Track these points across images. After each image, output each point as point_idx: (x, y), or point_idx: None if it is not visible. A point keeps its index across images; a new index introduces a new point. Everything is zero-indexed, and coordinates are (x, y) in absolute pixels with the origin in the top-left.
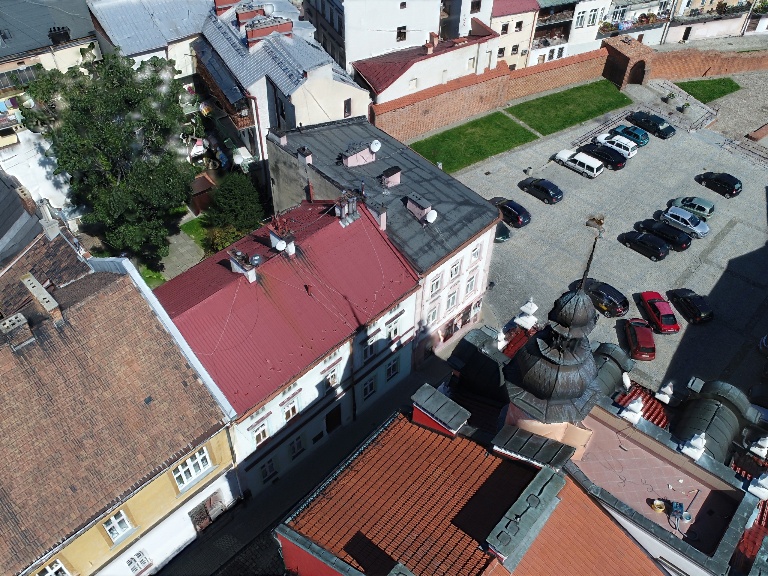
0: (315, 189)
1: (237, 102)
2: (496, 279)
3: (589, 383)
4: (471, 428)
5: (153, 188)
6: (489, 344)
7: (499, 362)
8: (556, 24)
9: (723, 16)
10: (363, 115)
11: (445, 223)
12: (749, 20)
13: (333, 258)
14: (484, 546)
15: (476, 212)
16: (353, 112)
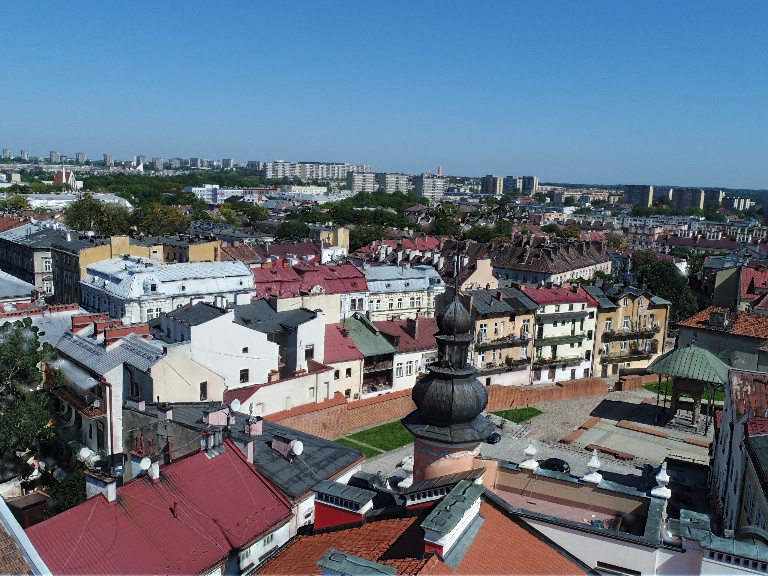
0: (175, 446)
1: (89, 397)
2: None
3: (482, 400)
4: (379, 509)
5: (1, 427)
6: (379, 485)
7: (392, 493)
8: (380, 373)
9: (512, 367)
10: (218, 401)
11: (311, 460)
12: (533, 372)
13: (200, 485)
14: (419, 556)
15: (340, 452)
16: (209, 396)
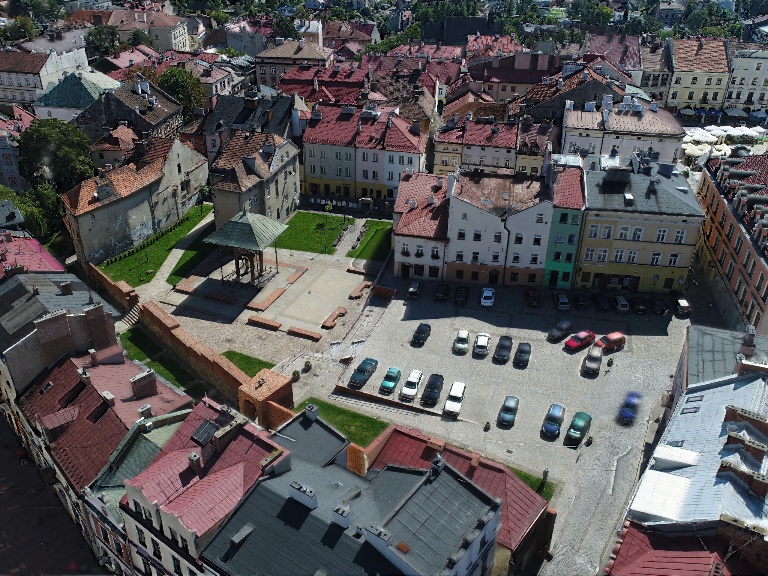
0: None
1: None
2: (625, 411)
3: None
4: None
5: None
6: None
7: None
8: None
9: None
10: None
11: None
12: None
13: None
14: None
15: (707, 330)
16: None
